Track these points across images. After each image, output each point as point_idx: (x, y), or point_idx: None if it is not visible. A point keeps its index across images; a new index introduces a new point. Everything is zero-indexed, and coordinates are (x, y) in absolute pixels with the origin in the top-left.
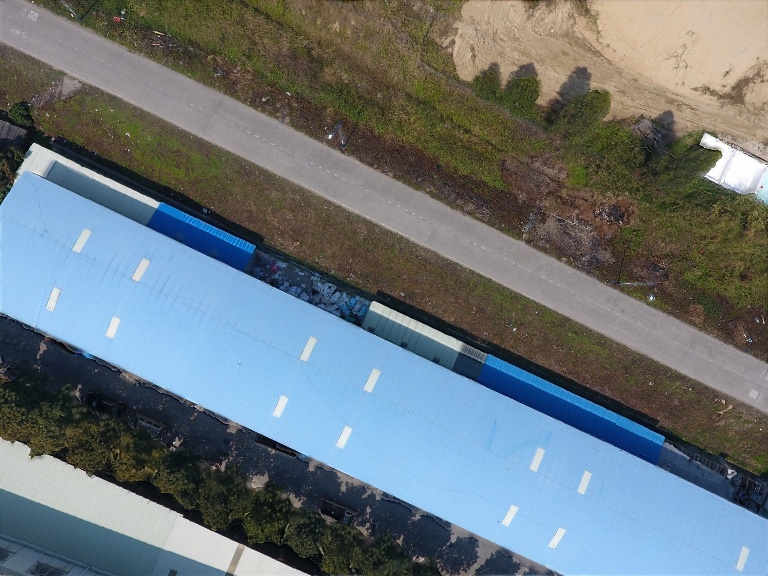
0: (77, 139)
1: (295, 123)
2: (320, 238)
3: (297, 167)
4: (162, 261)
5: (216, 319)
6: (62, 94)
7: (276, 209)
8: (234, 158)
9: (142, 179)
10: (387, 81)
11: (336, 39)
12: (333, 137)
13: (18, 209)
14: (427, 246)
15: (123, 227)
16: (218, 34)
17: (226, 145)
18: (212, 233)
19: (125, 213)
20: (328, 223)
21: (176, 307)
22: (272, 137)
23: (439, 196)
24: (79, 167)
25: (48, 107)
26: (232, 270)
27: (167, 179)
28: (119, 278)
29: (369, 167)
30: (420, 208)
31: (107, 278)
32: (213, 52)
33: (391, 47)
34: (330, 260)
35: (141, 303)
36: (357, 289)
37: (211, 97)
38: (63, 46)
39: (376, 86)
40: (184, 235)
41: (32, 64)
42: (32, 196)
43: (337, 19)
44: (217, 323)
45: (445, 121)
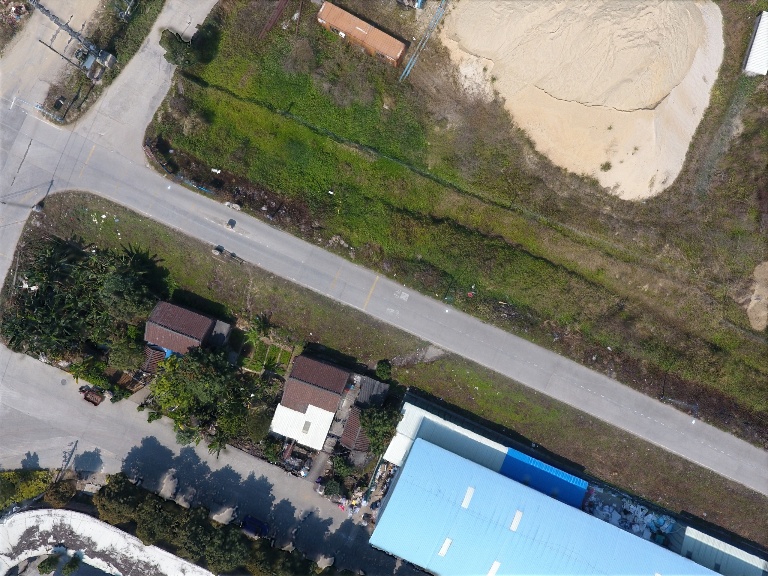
0: (427, 388)
1: (621, 378)
2: (638, 471)
3: (623, 415)
4: (532, 512)
5: (579, 561)
6: (425, 358)
7: (602, 449)
8: (571, 410)
9: (480, 419)
10: (685, 329)
11: (643, 296)
12: (652, 388)
13: (416, 473)
14: (735, 479)
15: (497, 483)
16: (553, 303)
17: (564, 398)
18: (552, 473)
19: (482, 459)
20: (648, 461)
21: (547, 552)
22: (602, 390)
23: (744, 436)
24: (443, 421)
25: (409, 366)
26: (586, 515)
27: (501, 419)
28: (500, 529)
29: (684, 413)
30: (728, 447)
31: (490, 529)
32: (548, 317)
33: (695, 306)
34: (642, 487)
35: (518, 550)
36: (662, 508)
37: (550, 358)
38: (429, 321)
39: (679, 336)
40: (531, 476)
41: (405, 337)
42: (425, 460)
43: (648, 283)
44: (580, 565)
45: (739, 364)
